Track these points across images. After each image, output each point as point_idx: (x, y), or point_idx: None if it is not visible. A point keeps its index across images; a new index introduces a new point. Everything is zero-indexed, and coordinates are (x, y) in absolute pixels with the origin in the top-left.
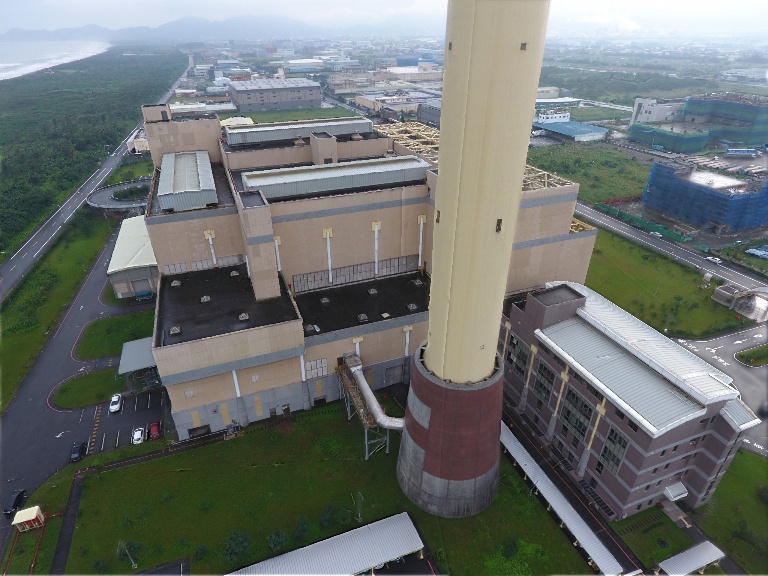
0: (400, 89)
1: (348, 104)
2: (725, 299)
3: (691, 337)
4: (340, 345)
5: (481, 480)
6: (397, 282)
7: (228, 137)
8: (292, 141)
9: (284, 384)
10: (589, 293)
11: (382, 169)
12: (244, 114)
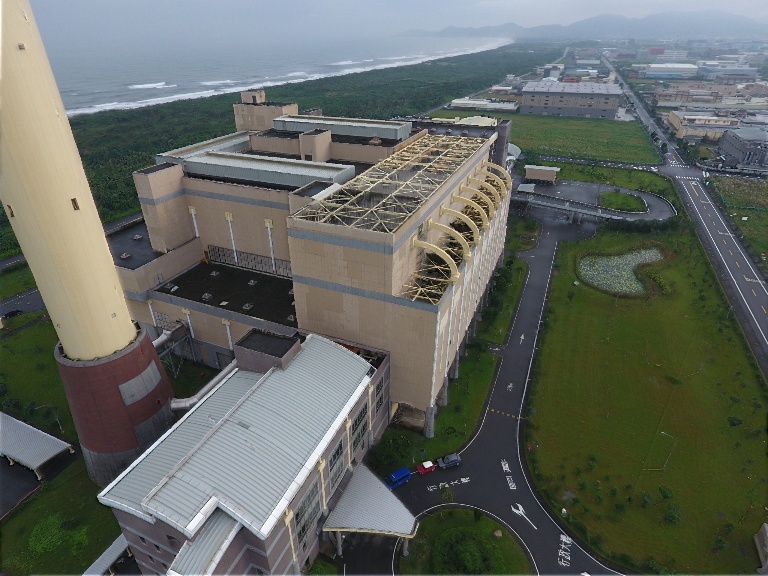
0: (752, 109)
1: (655, 119)
2: (765, 550)
3: (589, 545)
4: (175, 309)
5: (95, 456)
6: (284, 285)
7: (274, 123)
8: None
9: (144, 321)
10: (336, 367)
11: (288, 170)
12: (520, 116)
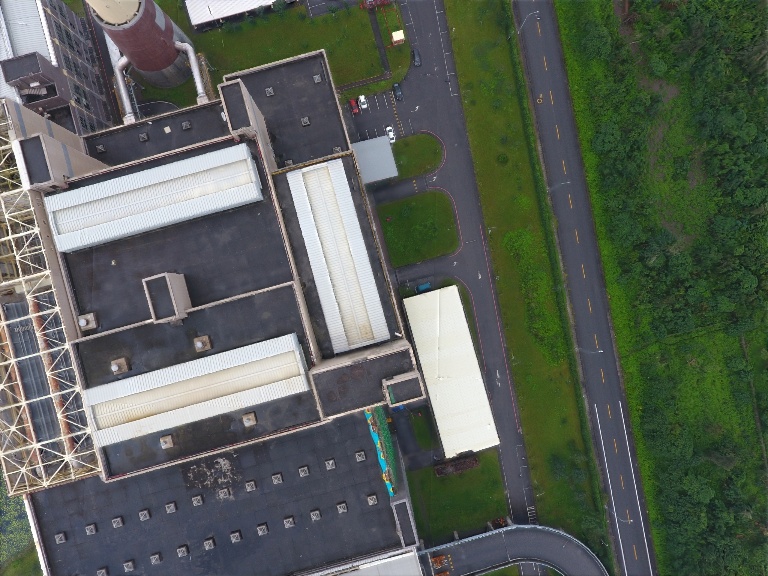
0: None
1: None
2: None
3: None
4: None
5: None
6: None
7: None
8: (213, 352)
9: None
10: None
11: (102, 188)
12: None
